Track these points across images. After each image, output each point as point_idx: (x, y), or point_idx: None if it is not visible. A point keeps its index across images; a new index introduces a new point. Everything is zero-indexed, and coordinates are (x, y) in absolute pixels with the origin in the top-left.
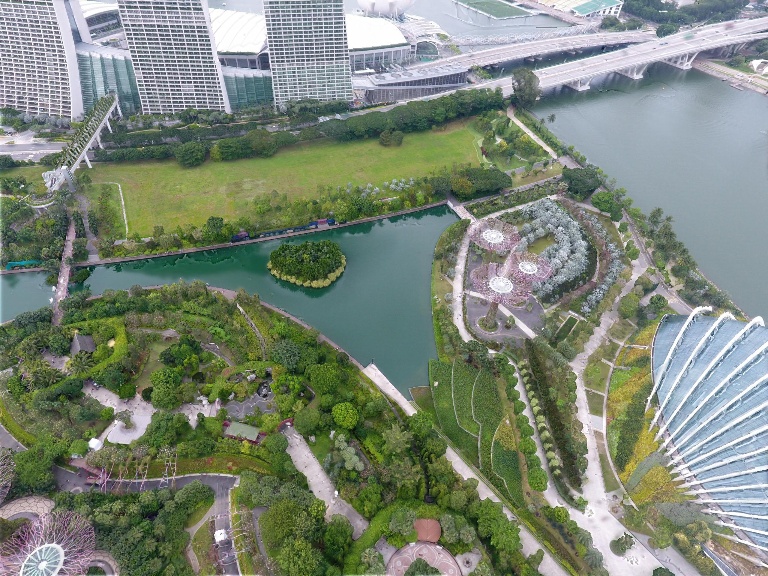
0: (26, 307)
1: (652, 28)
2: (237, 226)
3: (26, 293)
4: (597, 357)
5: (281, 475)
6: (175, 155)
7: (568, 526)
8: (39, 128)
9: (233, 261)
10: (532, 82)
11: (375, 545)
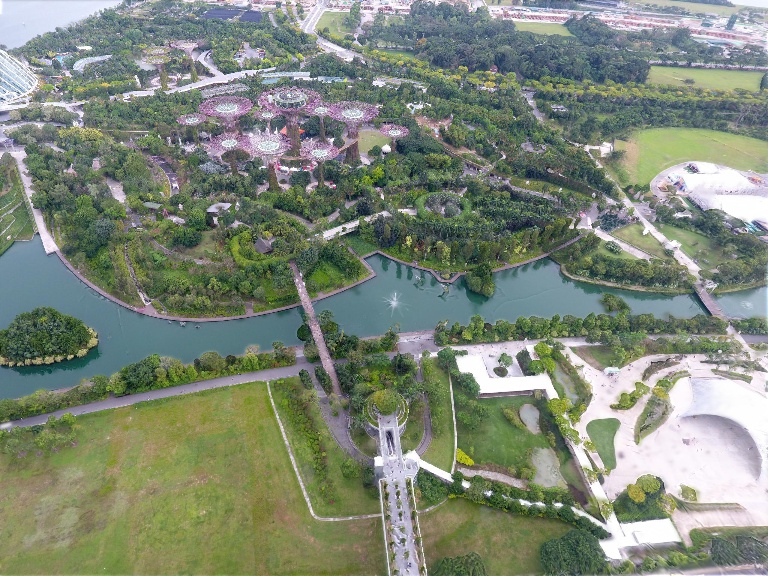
0: (345, 307)
1: None
2: None
3: None
4: None
5: None
6: None
7: None
8: None
9: None
10: None
11: None
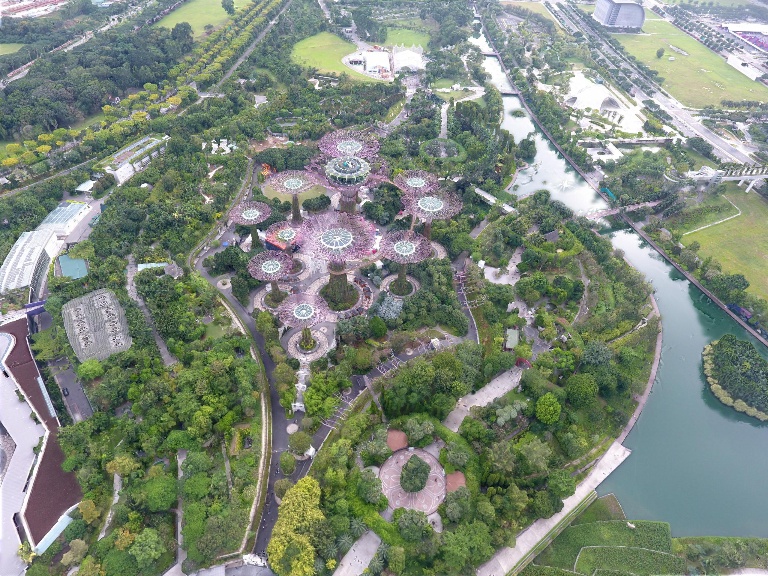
0: (575, 210)
1: None
2: (750, 301)
3: (586, 206)
4: None
5: (483, 369)
6: None
7: None
8: (765, 148)
9: (710, 322)
10: None
11: (440, 441)
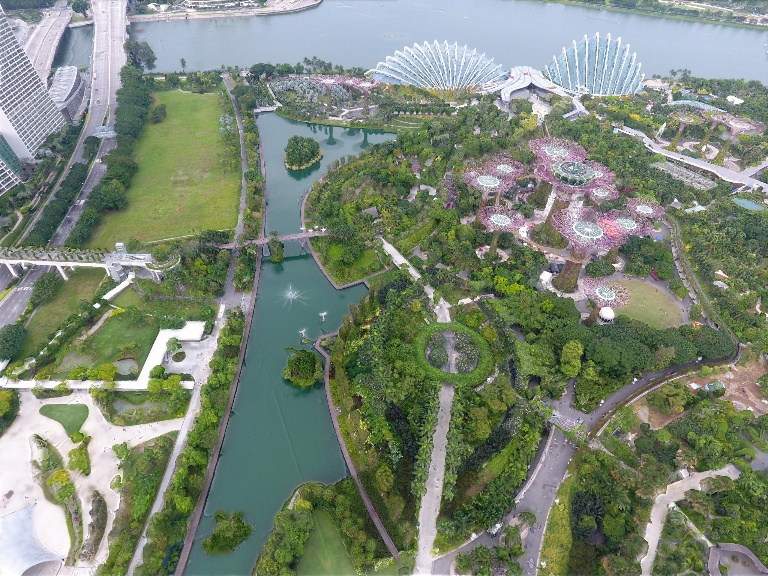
0: None
1: (46, 12)
2: None
3: None
4: (395, 91)
5: None
6: (108, 205)
7: (465, 109)
8: None
9: (266, 199)
10: (148, 46)
11: None
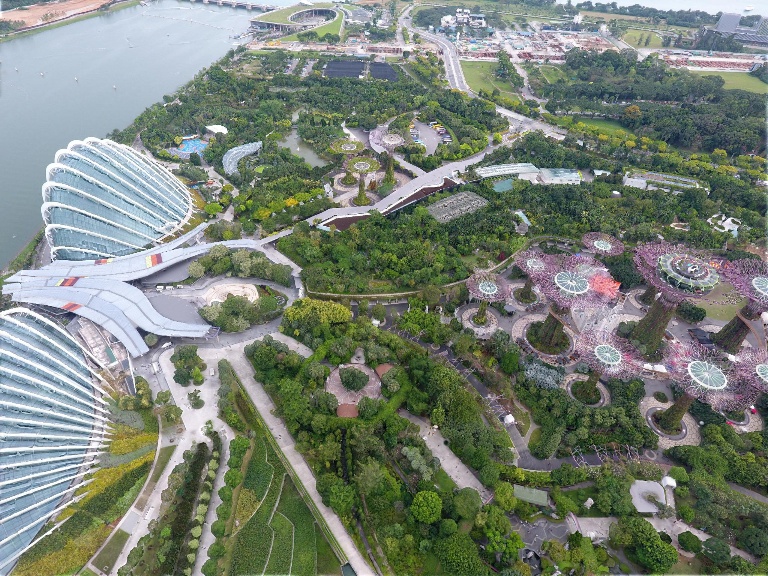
0: None
1: None
2: None
3: None
4: None
5: None
6: None
7: None
8: None
9: None
10: None
11: None
